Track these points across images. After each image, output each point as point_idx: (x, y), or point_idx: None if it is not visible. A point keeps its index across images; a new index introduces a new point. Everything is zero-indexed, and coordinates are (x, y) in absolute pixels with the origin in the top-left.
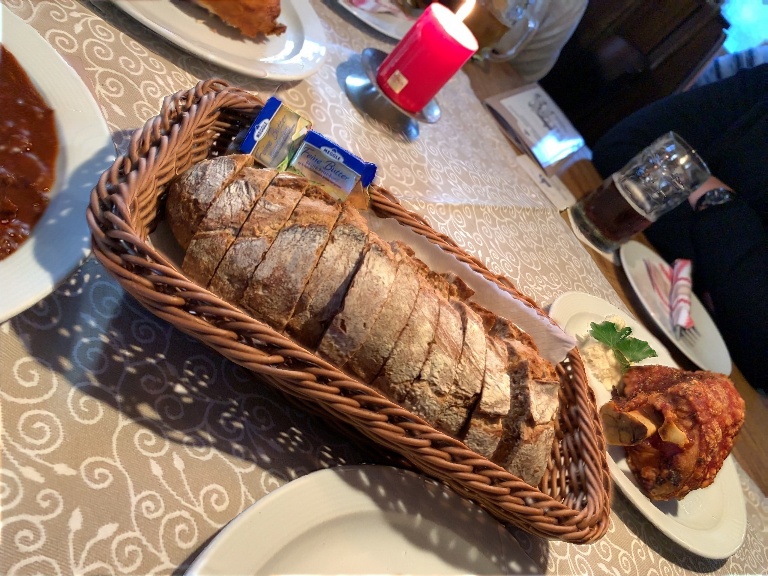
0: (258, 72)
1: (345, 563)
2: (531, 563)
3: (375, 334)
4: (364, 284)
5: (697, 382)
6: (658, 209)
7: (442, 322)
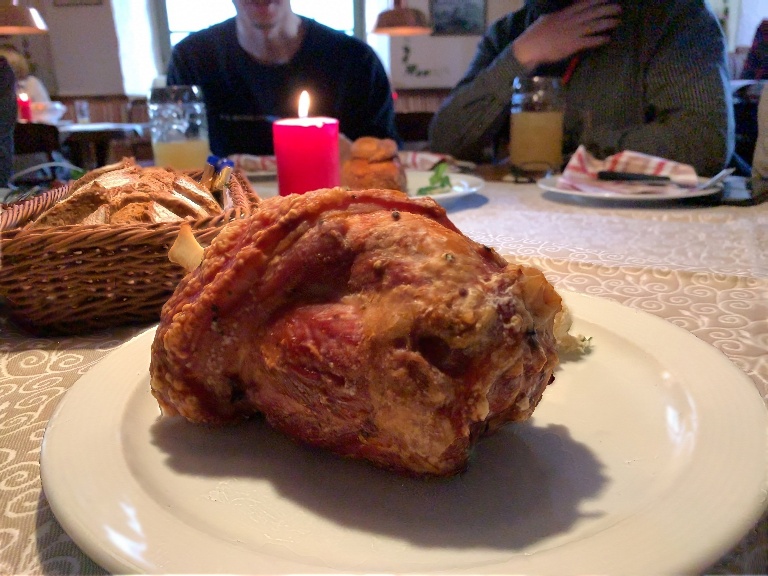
0: None
1: None
2: None
3: None
4: None
5: None
6: None
7: None
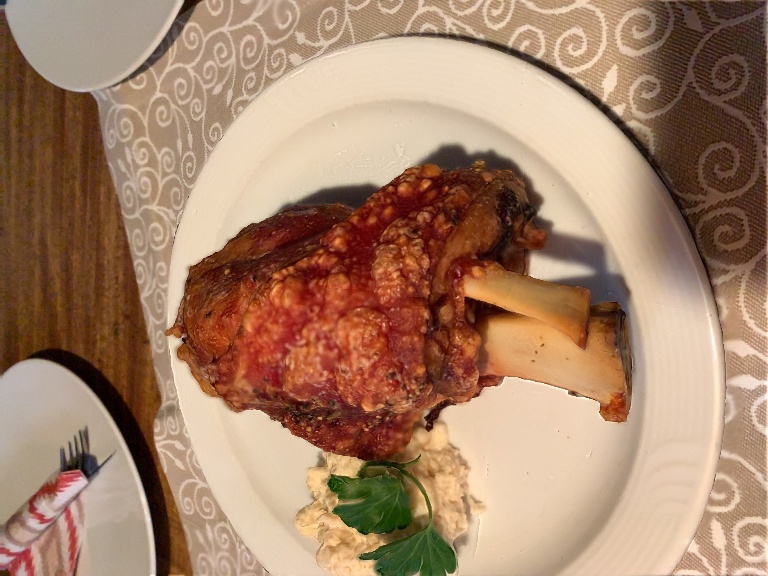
0: None
1: None
2: None
3: None
4: None
5: (368, 405)
6: None
7: None
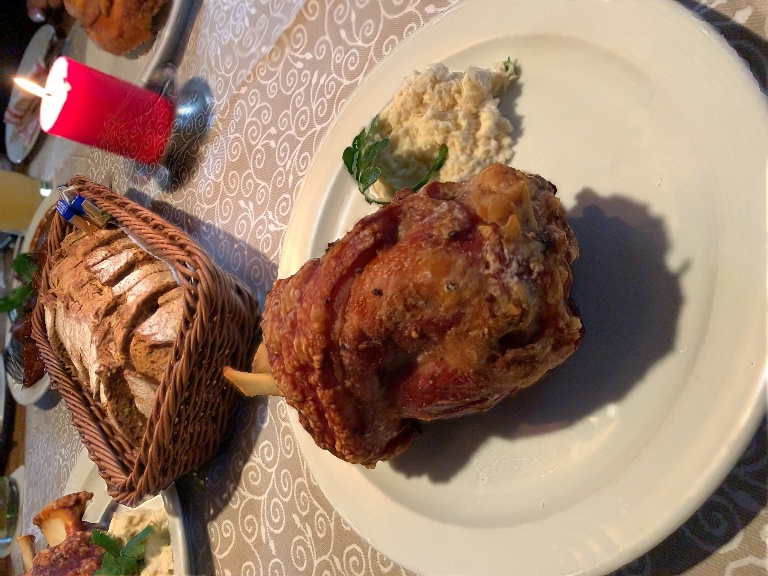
0: (137, 87)
1: None
2: (170, 501)
3: None
4: None
5: None
6: None
7: None
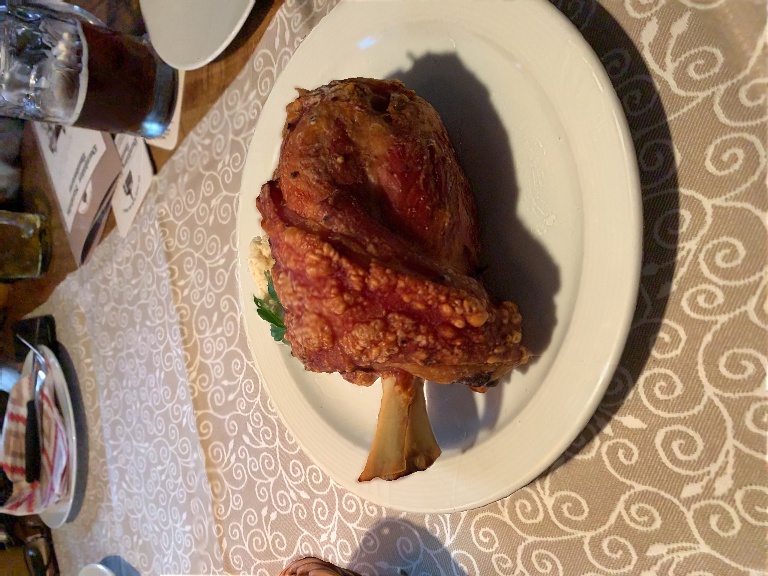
0: None
1: None
2: None
3: None
4: None
5: None
6: (63, 58)
7: None
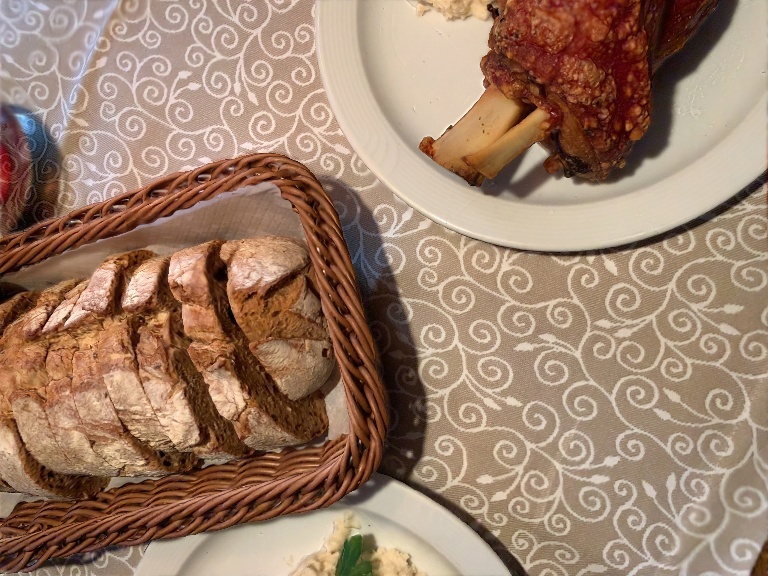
0: None
1: (219, 575)
2: None
3: (61, 469)
4: (2, 467)
5: (511, 3)
6: None
7: (83, 416)
